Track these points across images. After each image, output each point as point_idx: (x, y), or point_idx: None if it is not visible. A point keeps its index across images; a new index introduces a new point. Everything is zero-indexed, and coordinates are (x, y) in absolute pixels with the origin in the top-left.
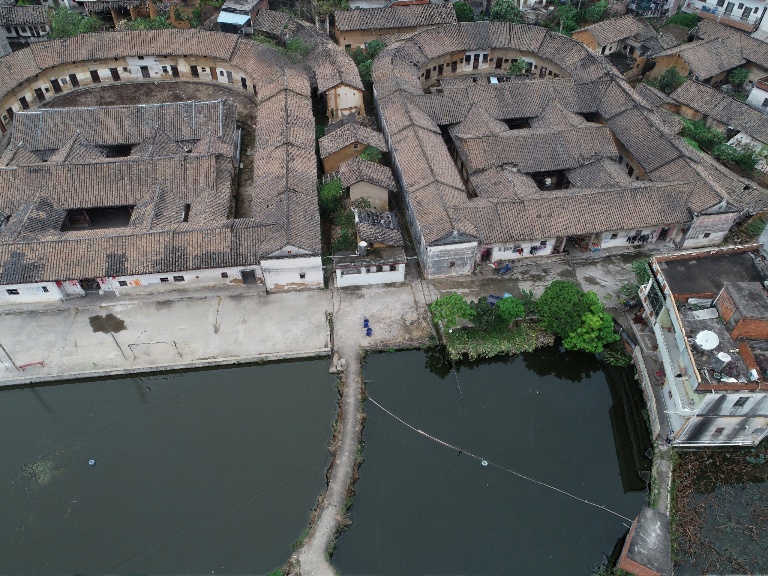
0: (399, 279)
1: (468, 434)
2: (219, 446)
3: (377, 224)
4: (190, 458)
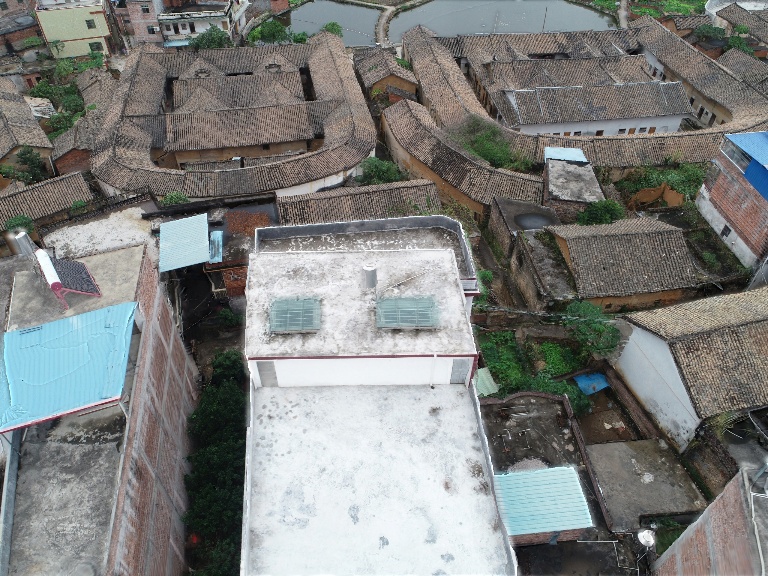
0: None
1: None
2: (435, 30)
3: None
4: (445, 27)
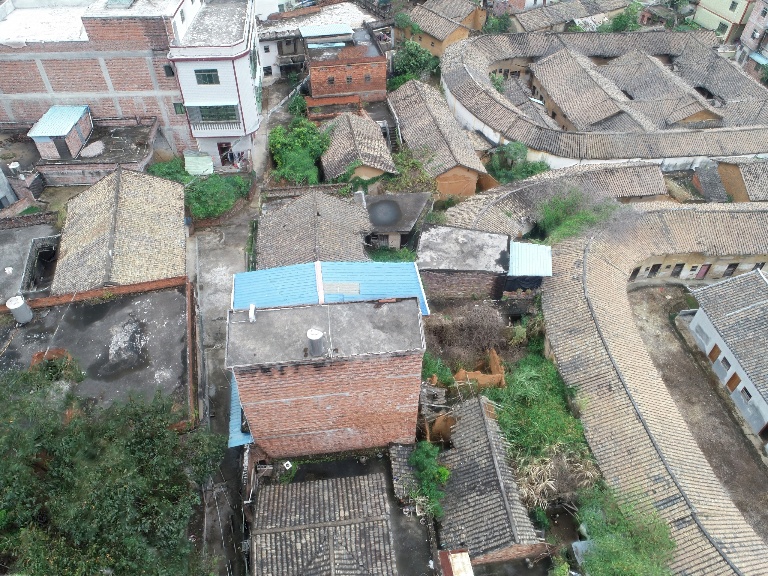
0: None
1: None
2: None
3: None
4: None
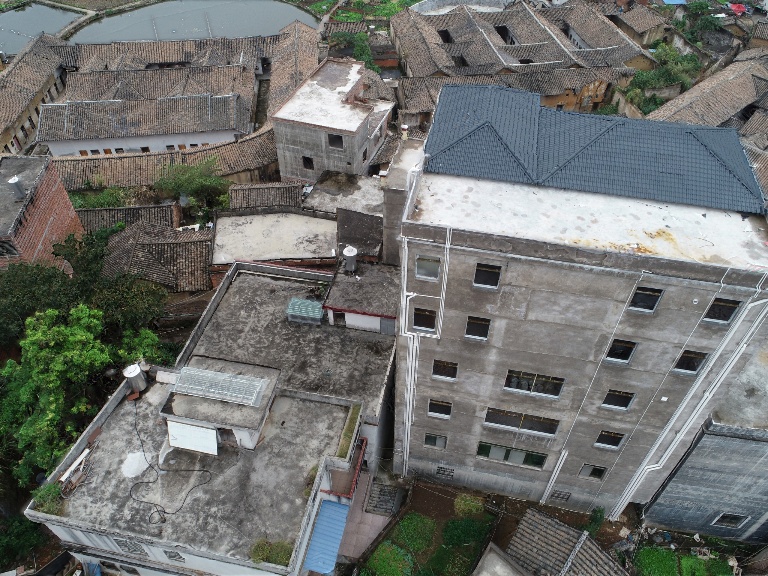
0: None
1: None
2: None
3: None
4: (134, 33)
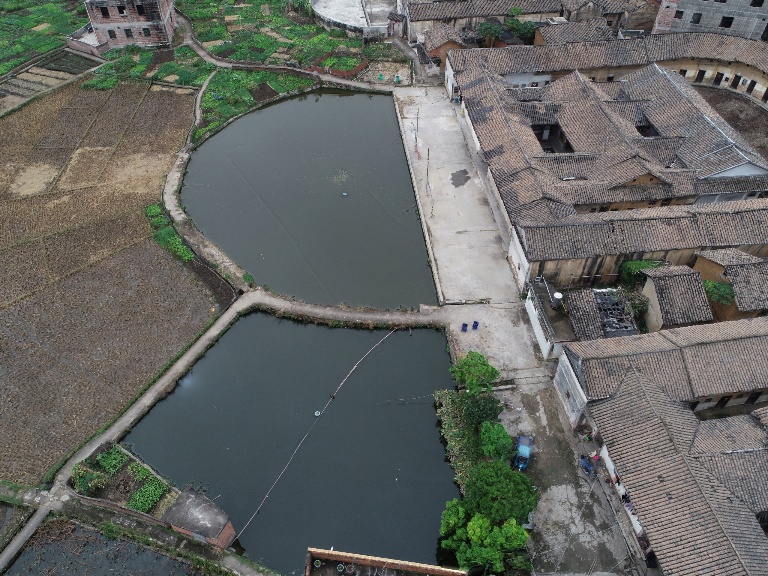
0: (544, 353)
1: (351, 406)
2: (353, 249)
3: (603, 312)
4: (344, 236)
